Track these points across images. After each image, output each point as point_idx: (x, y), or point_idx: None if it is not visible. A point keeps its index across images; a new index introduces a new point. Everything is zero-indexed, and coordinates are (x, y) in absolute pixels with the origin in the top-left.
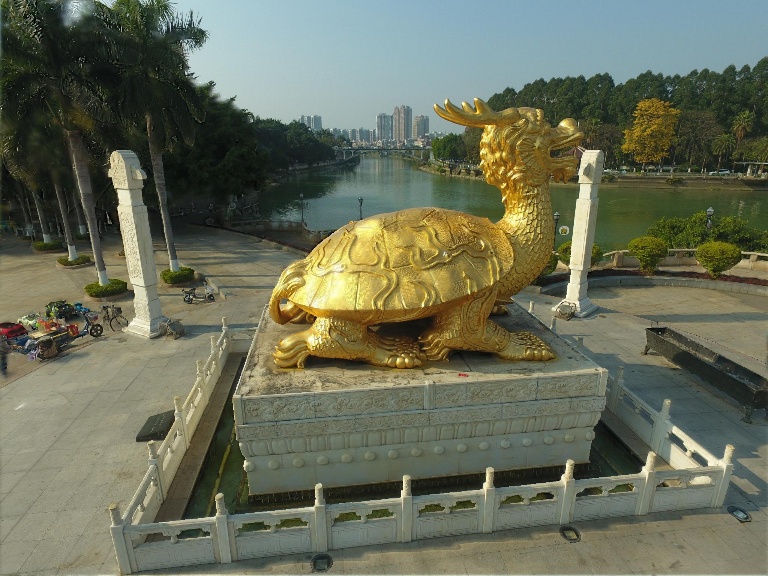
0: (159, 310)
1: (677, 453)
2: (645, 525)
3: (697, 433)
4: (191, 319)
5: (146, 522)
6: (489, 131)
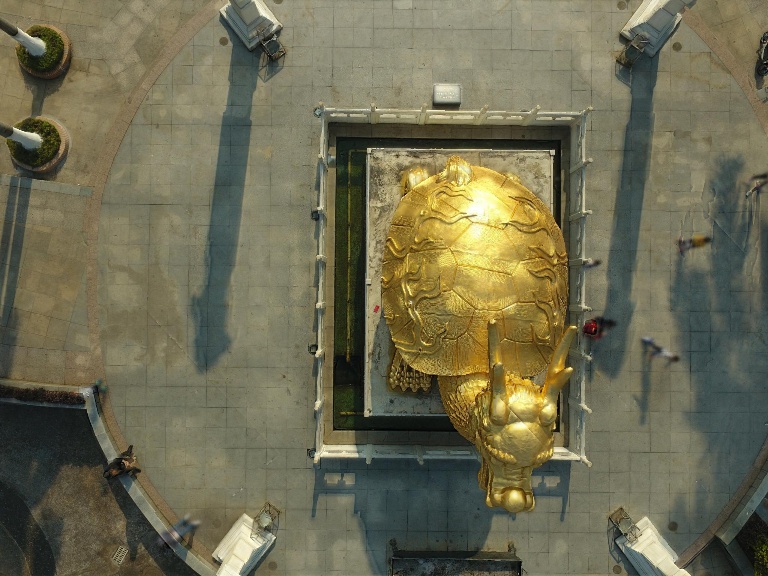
0: (662, 24)
1: (351, 449)
2: (313, 394)
3: (384, 491)
4: (678, 62)
5: (349, 119)
6: (507, 385)
